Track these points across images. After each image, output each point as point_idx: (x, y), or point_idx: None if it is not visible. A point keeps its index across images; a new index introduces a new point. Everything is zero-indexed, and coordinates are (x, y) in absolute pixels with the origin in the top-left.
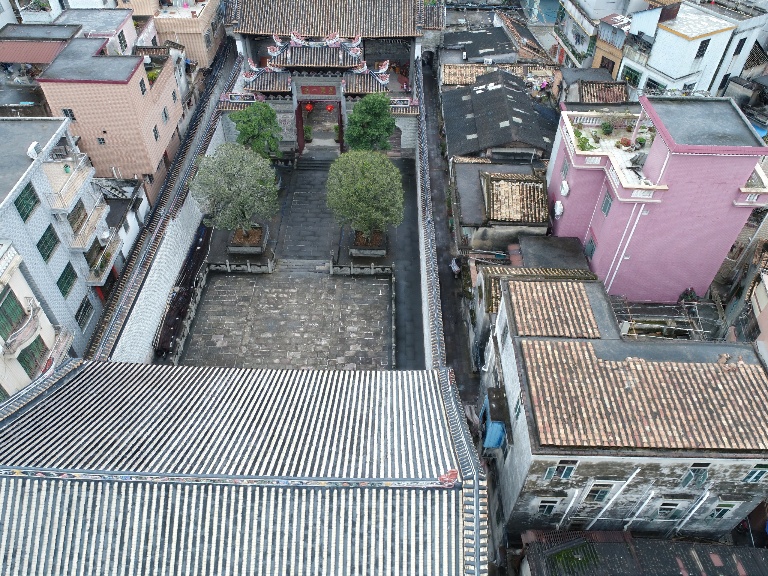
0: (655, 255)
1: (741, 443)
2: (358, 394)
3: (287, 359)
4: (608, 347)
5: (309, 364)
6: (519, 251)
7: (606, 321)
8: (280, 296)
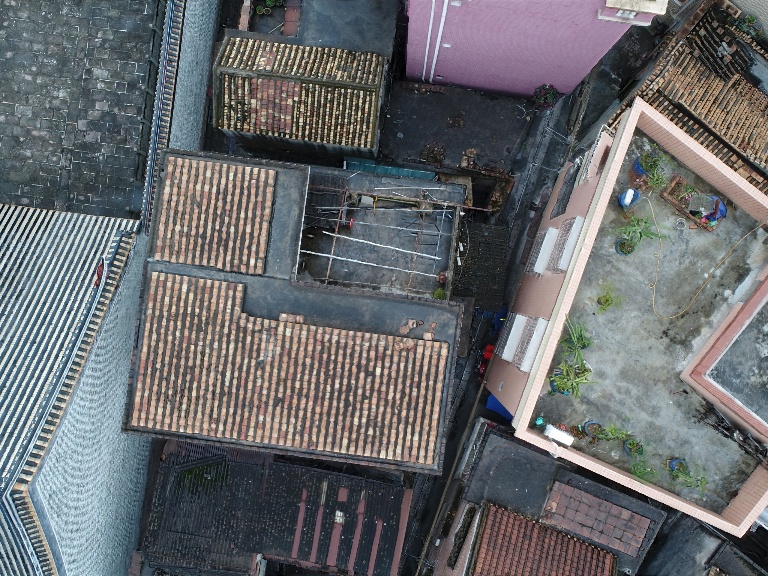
0: (488, 48)
1: (361, 448)
2: (4, 267)
3: (15, 117)
4: (266, 291)
5: (42, 128)
6: (301, 1)
7: (284, 244)
8: (6, 4)
